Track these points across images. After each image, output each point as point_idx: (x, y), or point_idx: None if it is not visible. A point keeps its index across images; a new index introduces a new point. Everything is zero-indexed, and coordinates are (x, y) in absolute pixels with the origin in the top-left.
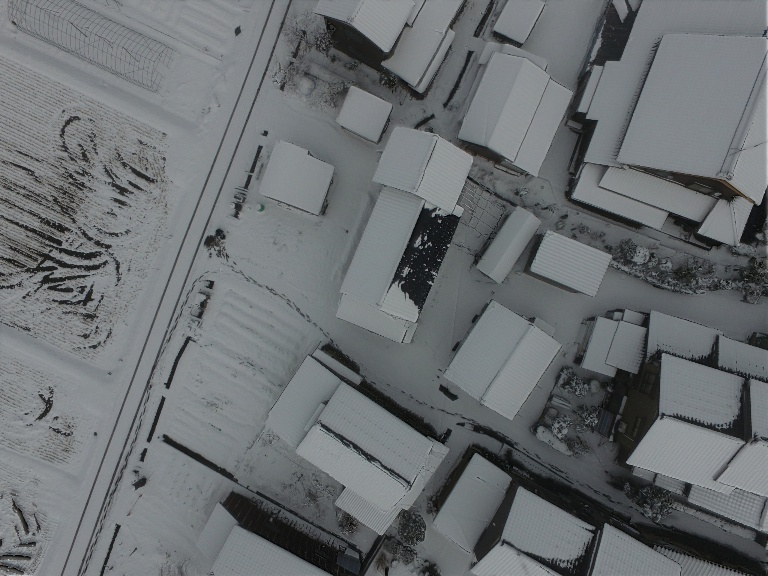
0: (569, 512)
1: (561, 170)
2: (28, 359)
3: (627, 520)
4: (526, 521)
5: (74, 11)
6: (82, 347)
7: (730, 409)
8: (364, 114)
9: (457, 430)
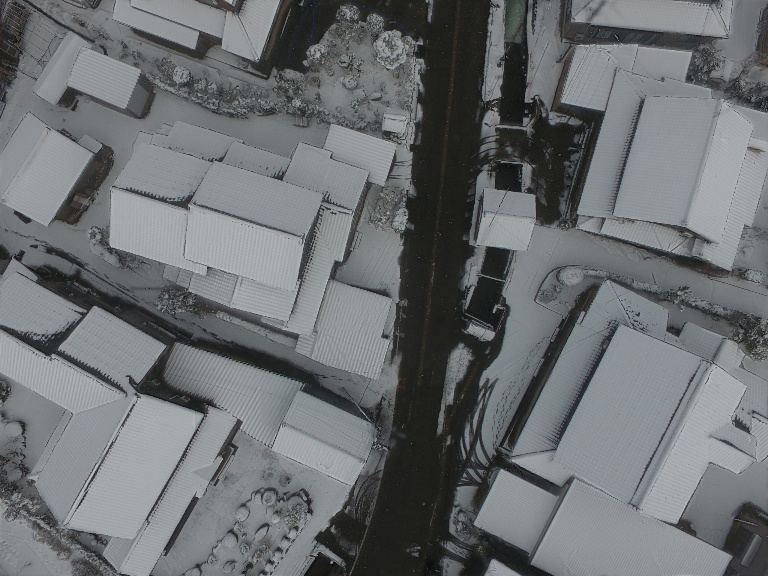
0: (62, 296)
1: None
2: None
3: (189, 336)
4: (9, 299)
5: None
6: None
7: (188, 186)
8: None
9: (30, 252)
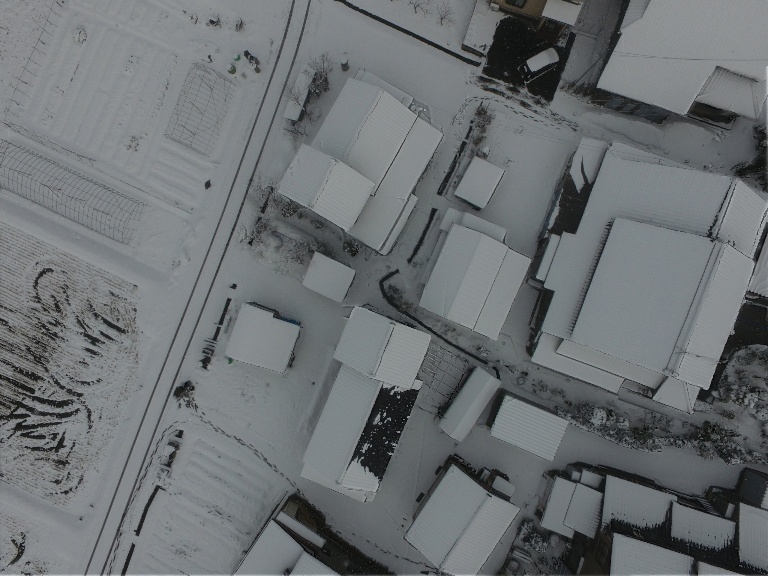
0: None
1: (522, 325)
2: (1, 505)
3: None
4: None
5: (47, 172)
6: (54, 493)
7: None
8: (328, 279)
9: None
